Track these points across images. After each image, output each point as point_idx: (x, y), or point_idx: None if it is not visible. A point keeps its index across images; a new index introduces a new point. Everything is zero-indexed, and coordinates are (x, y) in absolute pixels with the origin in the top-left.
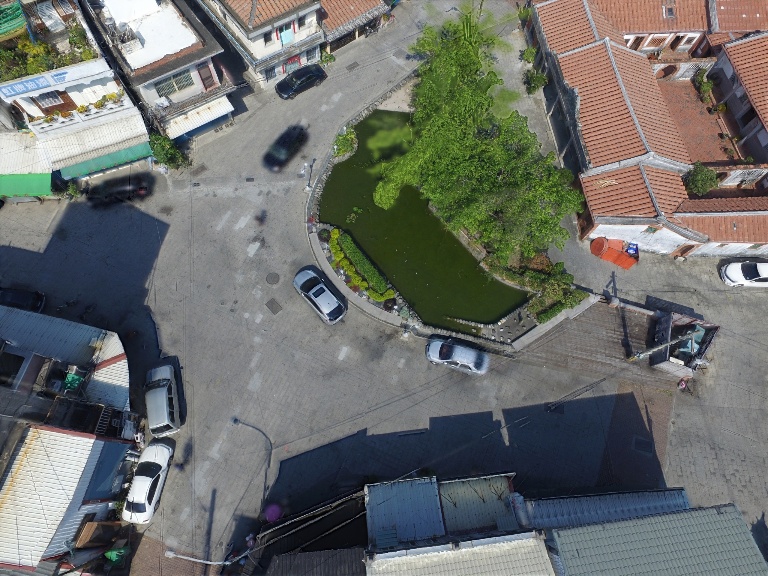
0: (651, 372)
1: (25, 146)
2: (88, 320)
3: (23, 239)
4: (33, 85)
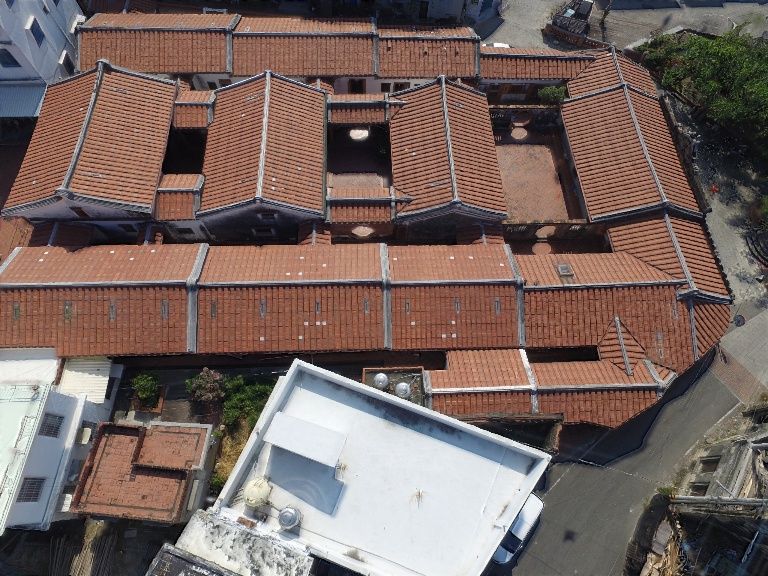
0: None
1: None
2: None
3: None
4: None
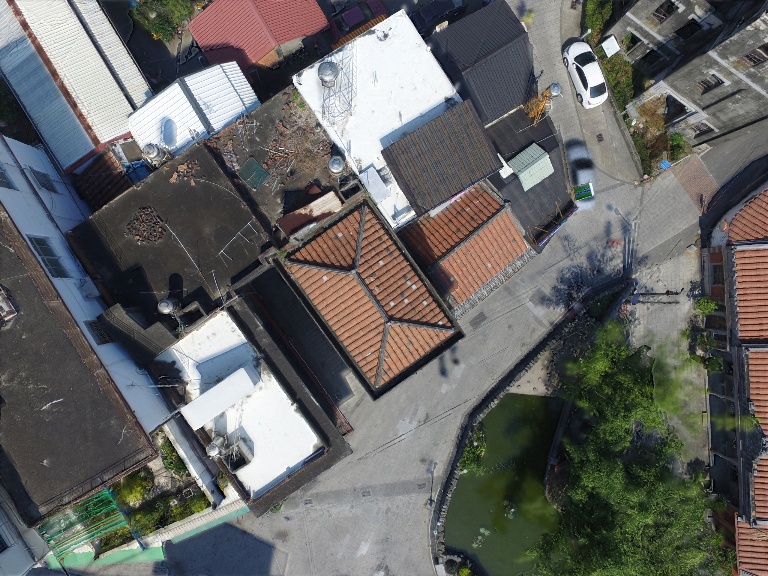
0: None
1: None
2: None
3: (140, 575)
4: None
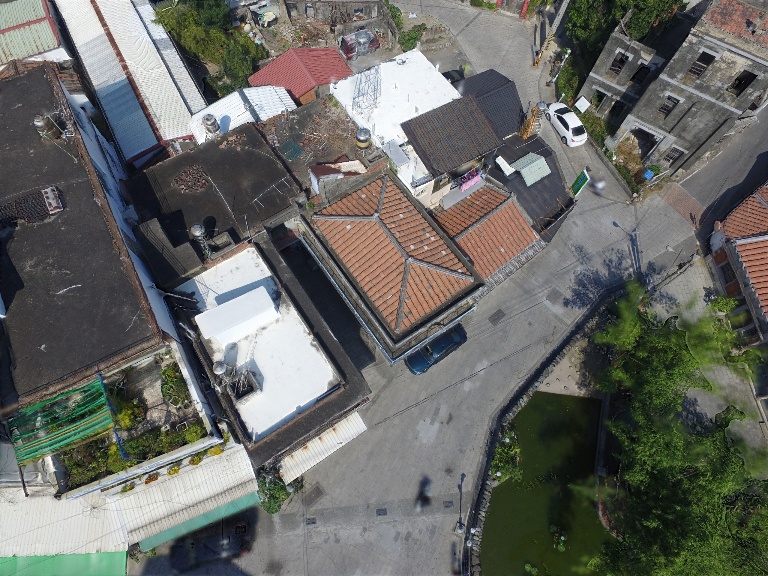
0: None
1: (91, 505)
2: None
3: None
4: (114, 480)
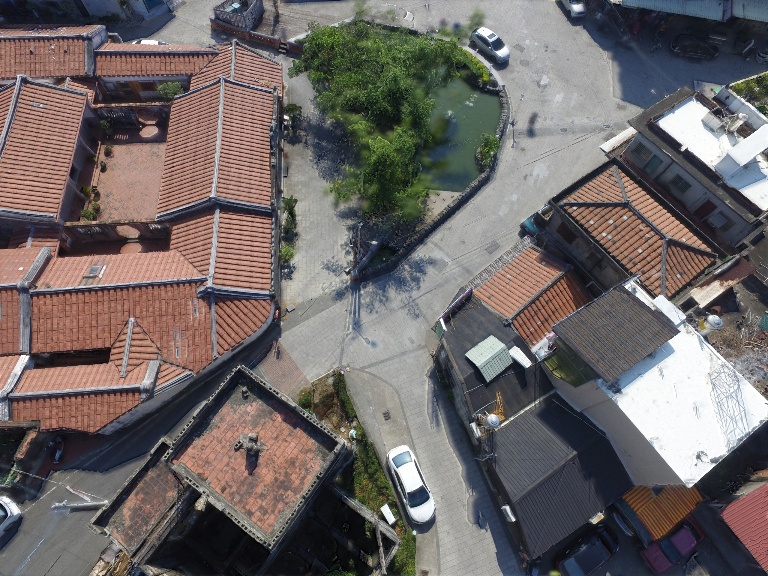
0: (265, 8)
1: None
2: (638, 43)
3: None
4: None
